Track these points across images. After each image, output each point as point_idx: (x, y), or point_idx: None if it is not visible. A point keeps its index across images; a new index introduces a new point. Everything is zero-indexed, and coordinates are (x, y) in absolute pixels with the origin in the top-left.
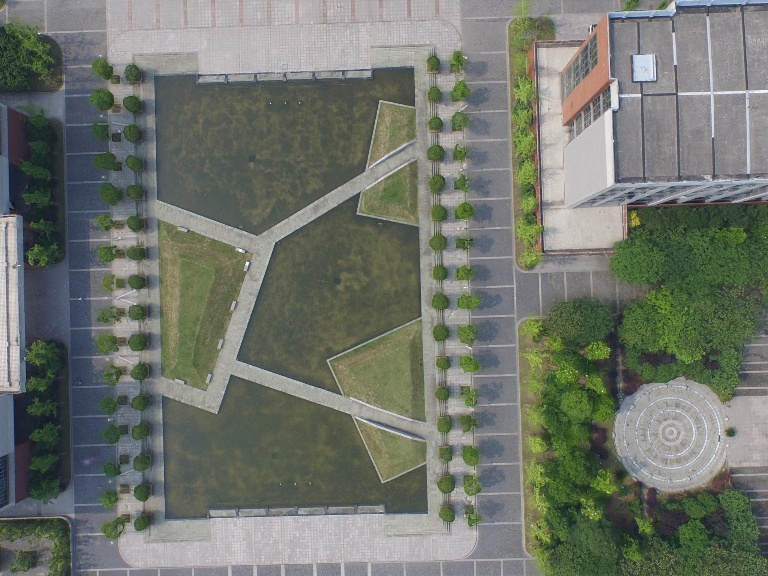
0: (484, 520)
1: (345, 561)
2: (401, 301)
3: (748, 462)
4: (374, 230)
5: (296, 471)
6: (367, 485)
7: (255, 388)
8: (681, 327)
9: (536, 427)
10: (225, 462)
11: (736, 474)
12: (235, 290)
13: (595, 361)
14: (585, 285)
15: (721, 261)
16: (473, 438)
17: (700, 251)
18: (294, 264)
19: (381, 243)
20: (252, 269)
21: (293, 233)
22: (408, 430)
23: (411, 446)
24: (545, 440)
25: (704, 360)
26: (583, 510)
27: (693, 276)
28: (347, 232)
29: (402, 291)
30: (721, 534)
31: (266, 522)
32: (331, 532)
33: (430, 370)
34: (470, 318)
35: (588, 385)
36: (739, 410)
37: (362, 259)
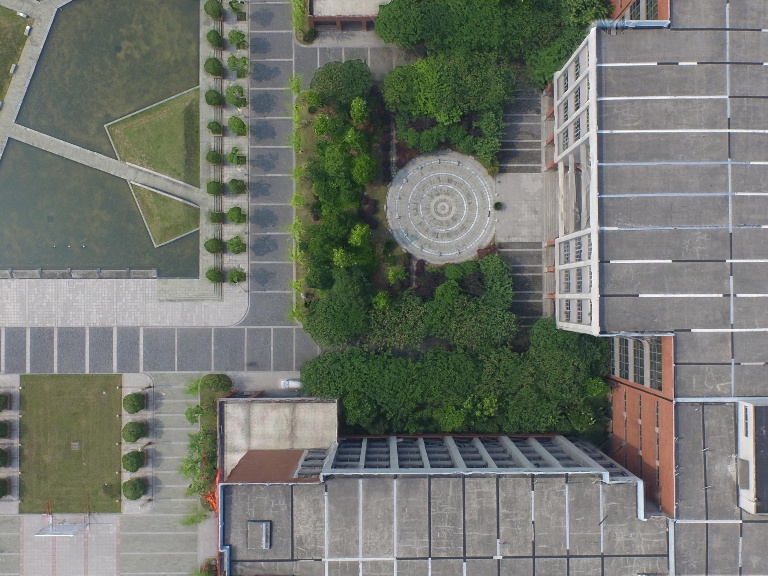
0: (256, 288)
1: (117, 325)
2: (180, 70)
3: (516, 237)
4: (156, 0)
5: (71, 235)
6: (141, 250)
7: (33, 152)
8: (436, 83)
9: (309, 197)
10: (1, 224)
11: (504, 249)
12: (15, 54)
13: (365, 130)
14: (363, 61)
15: (477, 20)
16: (248, 207)
17: (457, 10)
18: (76, 31)
19: (162, 13)
20: (33, 34)
21: (75, 0)
22: (182, 196)
23: (182, 209)
24: (316, 208)
25: (465, 124)
26: (334, 259)
27: (452, 37)
28: (129, 1)
29: (182, 61)
30: (475, 293)
31: (40, 284)
32: (104, 296)
33: (206, 138)
34: (249, 90)
35: (344, 139)
36: (509, 186)
37: (143, 28)
